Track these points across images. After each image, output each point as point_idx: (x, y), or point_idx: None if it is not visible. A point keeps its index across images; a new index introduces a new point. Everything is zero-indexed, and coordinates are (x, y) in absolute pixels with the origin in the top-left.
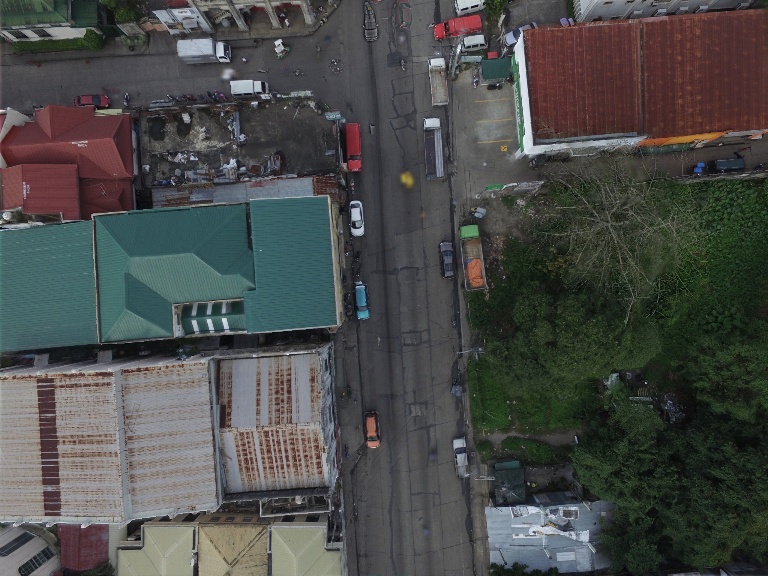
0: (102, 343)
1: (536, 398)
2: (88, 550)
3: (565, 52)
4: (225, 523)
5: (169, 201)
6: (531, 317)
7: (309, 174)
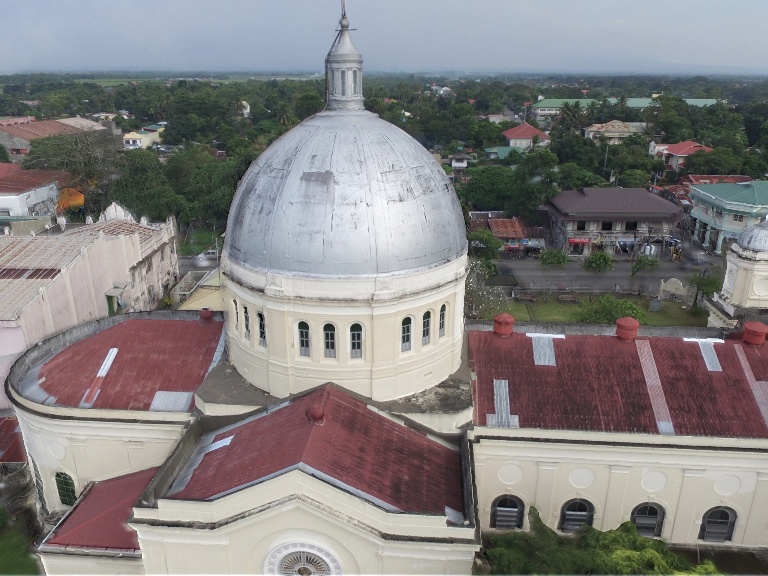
0: None
1: None
2: None
3: None
4: None
5: None
6: None
7: None
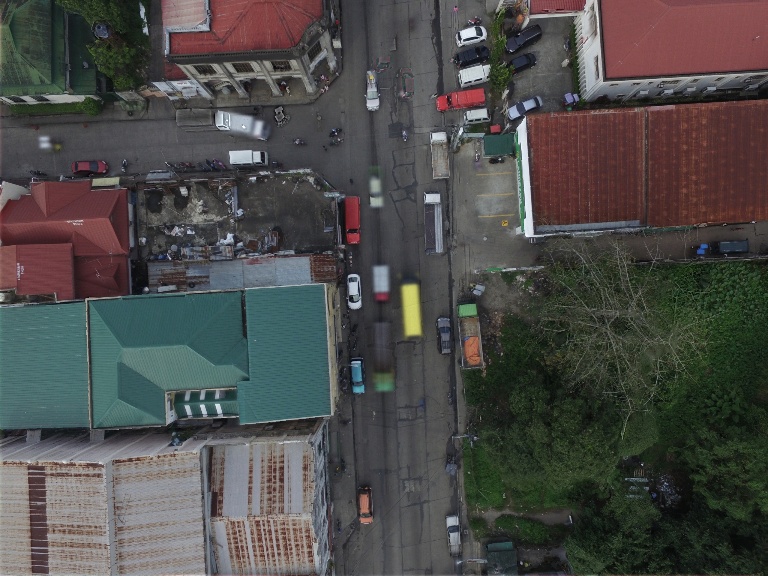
0: (94, 429)
1: None
2: None
3: (568, 139)
4: None
5: (165, 275)
6: (527, 409)
7: (307, 251)
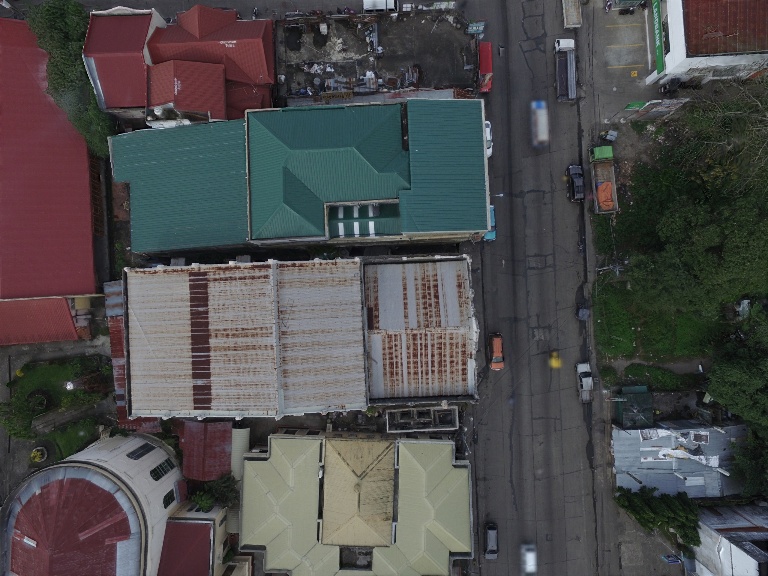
0: (253, 240)
1: (662, 325)
2: (212, 461)
3: None
4: (351, 438)
5: None
6: (681, 229)
7: (446, 88)
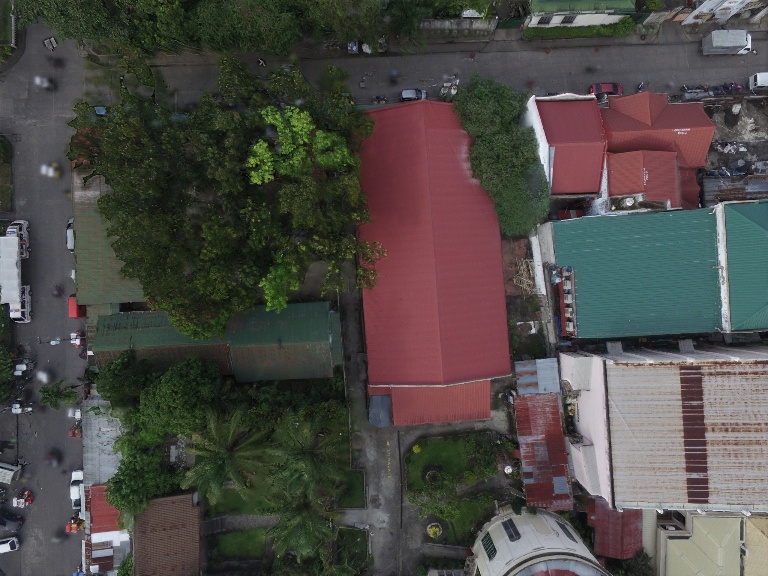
0: (733, 331)
1: None
2: (628, 539)
3: None
4: (767, 515)
5: (722, 191)
6: None
7: None
